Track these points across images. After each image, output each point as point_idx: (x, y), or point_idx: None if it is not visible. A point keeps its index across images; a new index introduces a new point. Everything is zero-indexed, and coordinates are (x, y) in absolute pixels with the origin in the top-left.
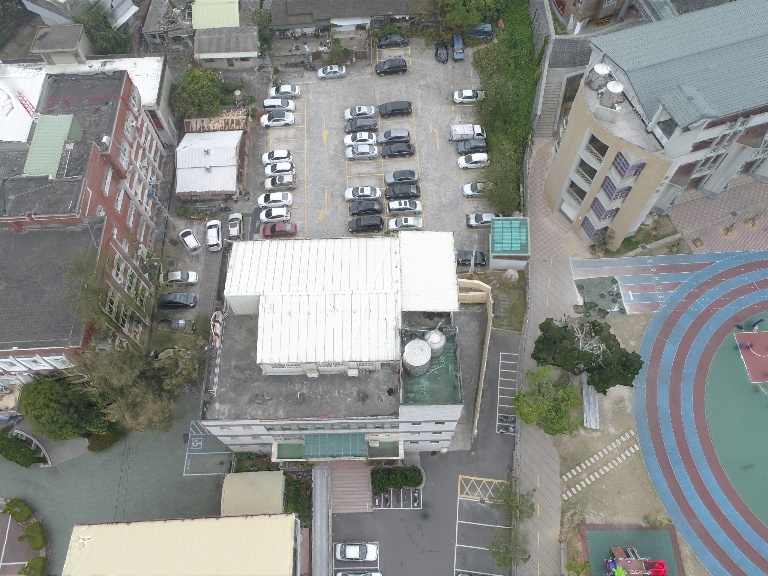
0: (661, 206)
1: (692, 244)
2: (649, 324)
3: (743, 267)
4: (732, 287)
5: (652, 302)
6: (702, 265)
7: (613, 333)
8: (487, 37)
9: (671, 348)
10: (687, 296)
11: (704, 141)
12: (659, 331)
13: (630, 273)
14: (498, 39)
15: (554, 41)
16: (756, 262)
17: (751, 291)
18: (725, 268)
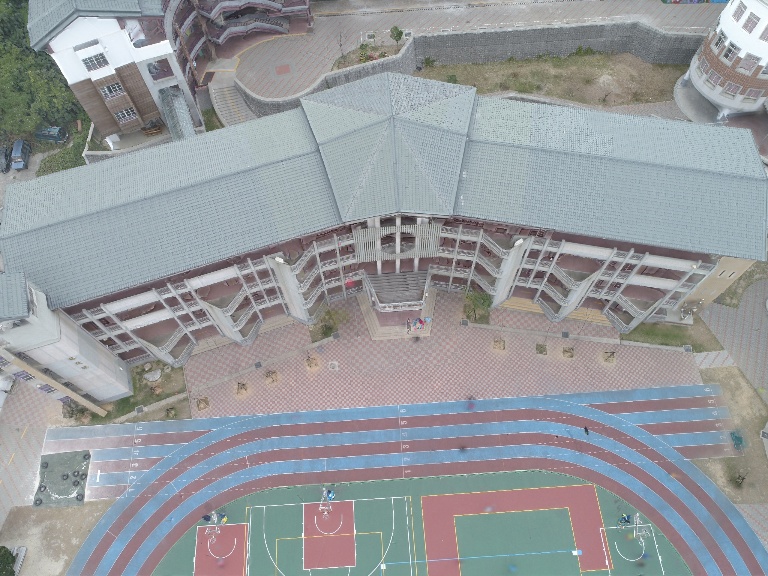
0: (165, 360)
1: (195, 406)
2: (104, 515)
3: (241, 437)
4: (218, 464)
5: (119, 485)
6: (195, 434)
7: (58, 528)
8: (58, 141)
9: (117, 548)
10: (162, 476)
11: (170, 298)
12: (112, 524)
13: (109, 446)
14: (73, 143)
15: (87, 157)
16: (258, 430)
17: (238, 469)
18: (220, 438)
